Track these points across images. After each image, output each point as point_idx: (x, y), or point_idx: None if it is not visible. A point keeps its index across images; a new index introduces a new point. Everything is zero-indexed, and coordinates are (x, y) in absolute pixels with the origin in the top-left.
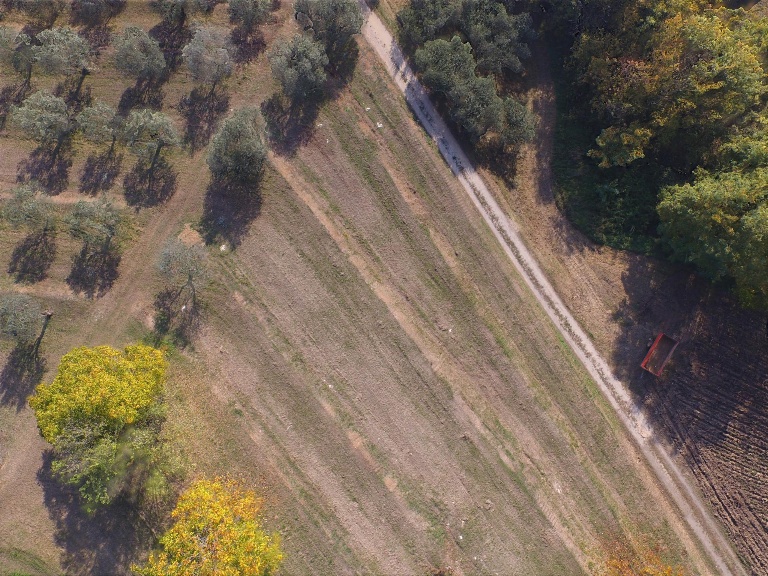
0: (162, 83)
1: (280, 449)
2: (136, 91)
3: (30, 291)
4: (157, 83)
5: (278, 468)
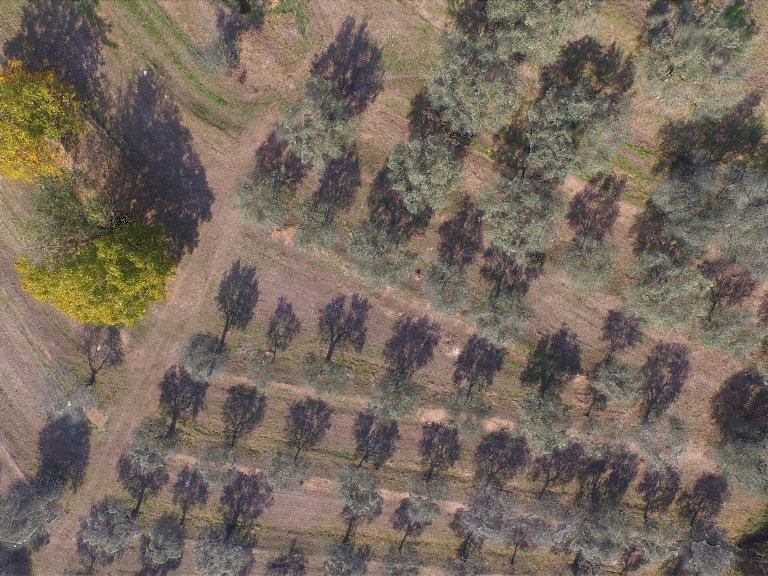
0: (142, 572)
1: (7, 202)
2: (167, 567)
3: (237, 378)
4: (147, 573)
5: (4, 184)
